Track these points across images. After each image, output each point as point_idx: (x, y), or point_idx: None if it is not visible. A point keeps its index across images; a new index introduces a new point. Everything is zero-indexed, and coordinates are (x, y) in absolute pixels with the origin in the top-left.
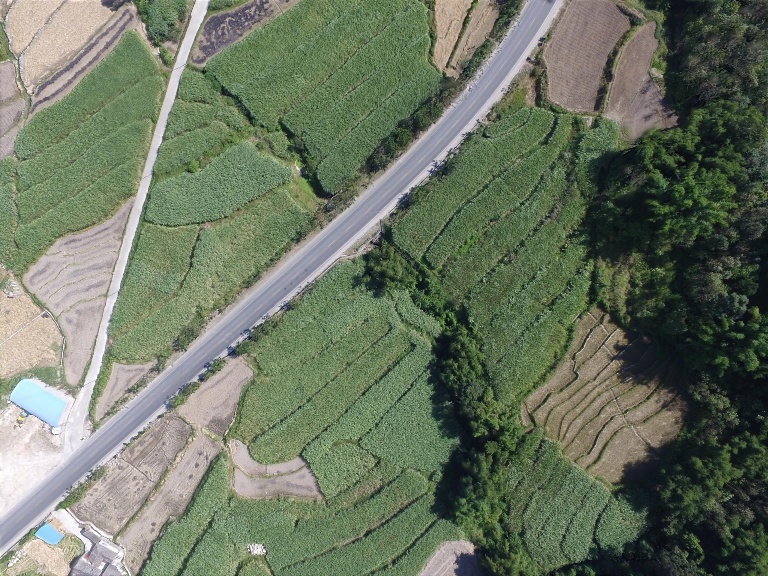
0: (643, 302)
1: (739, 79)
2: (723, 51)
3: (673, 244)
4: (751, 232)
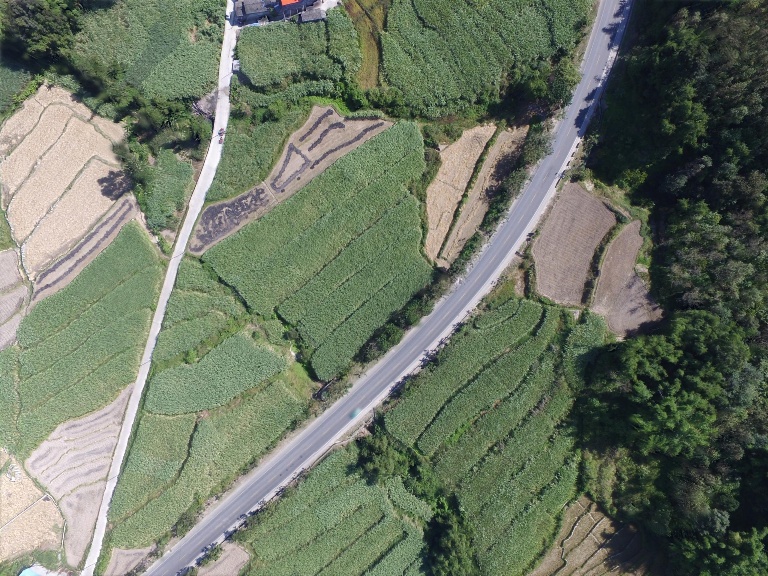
0: (629, 496)
1: (720, 290)
2: (705, 259)
3: (657, 451)
4: (731, 452)
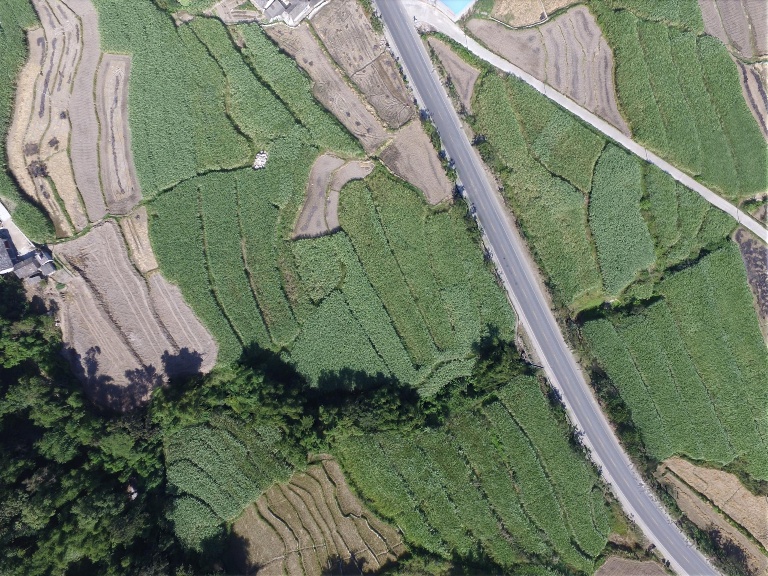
0: None
1: None
2: None
3: None
4: None
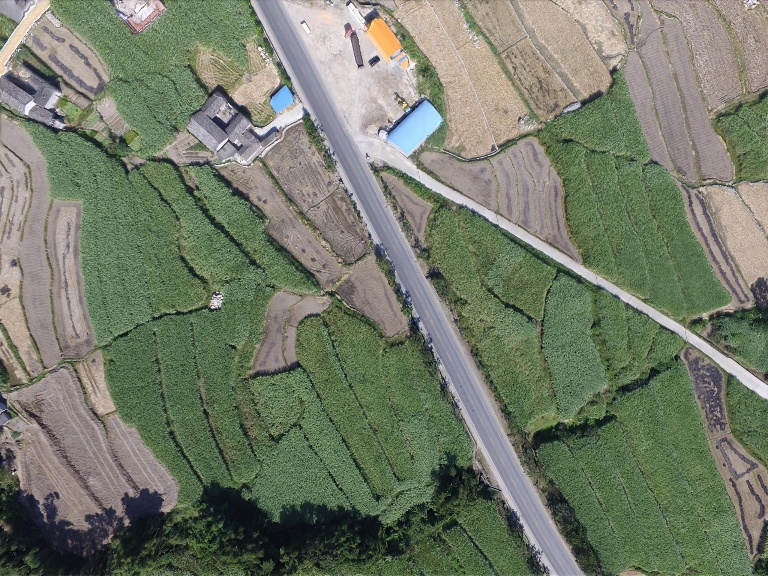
0: None
1: None
2: None
3: None
4: None
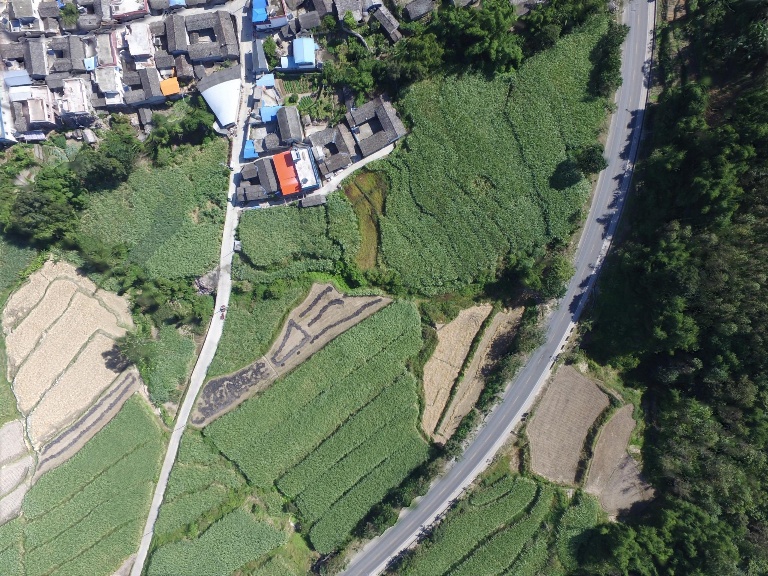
0: None
1: (711, 486)
2: (696, 452)
3: None
4: None
